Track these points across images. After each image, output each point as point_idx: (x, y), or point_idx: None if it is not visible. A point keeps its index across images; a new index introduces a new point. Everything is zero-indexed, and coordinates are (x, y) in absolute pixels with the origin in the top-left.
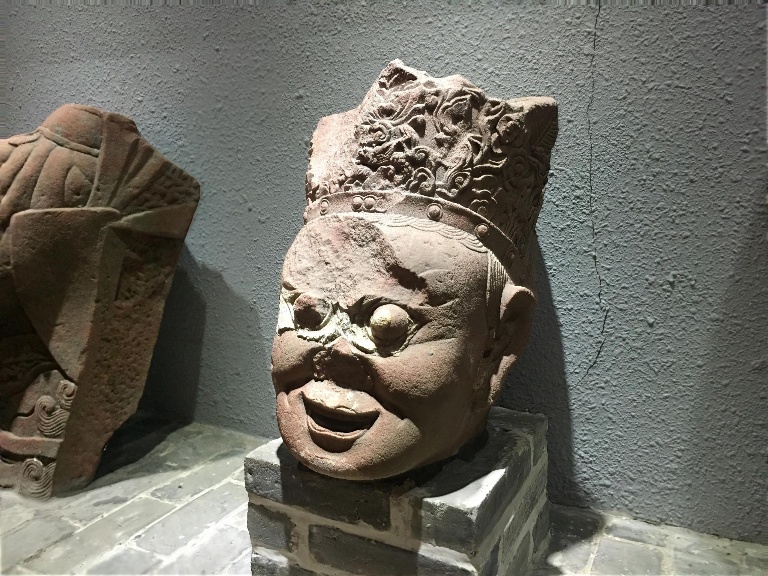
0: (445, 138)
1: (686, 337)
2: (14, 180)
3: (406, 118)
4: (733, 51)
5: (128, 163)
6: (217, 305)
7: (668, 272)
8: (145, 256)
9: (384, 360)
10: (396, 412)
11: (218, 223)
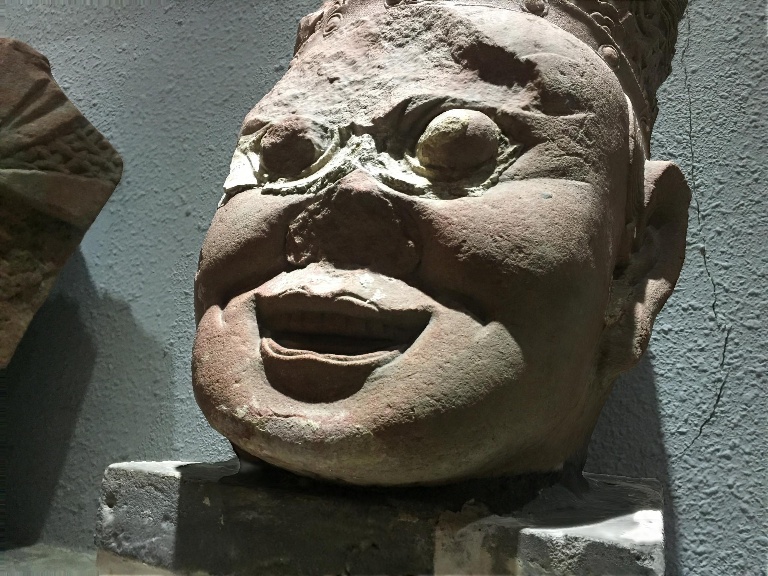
0: None
1: None
2: None
3: None
4: None
5: (25, 104)
6: (114, 351)
7: None
8: (18, 236)
9: (448, 202)
10: (470, 309)
11: (139, 234)
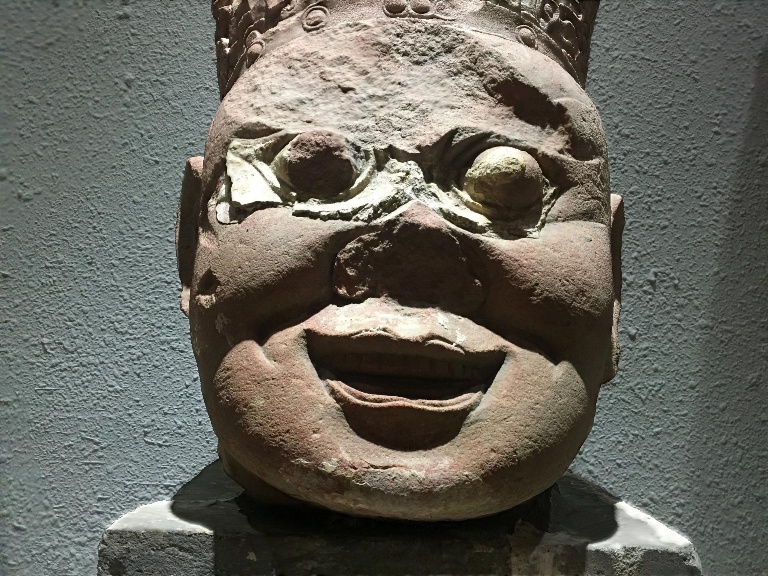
0: None
1: (674, 351)
2: None
3: None
4: (695, 29)
5: None
6: None
7: (648, 269)
8: None
9: (513, 243)
10: (542, 349)
11: None
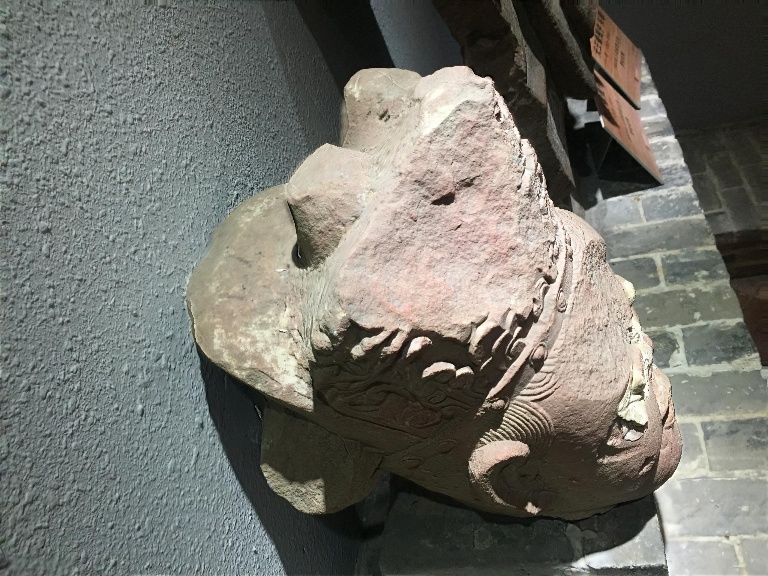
0: None
1: None
2: None
3: None
4: None
5: None
6: None
7: None
8: None
9: (635, 316)
10: None
11: None
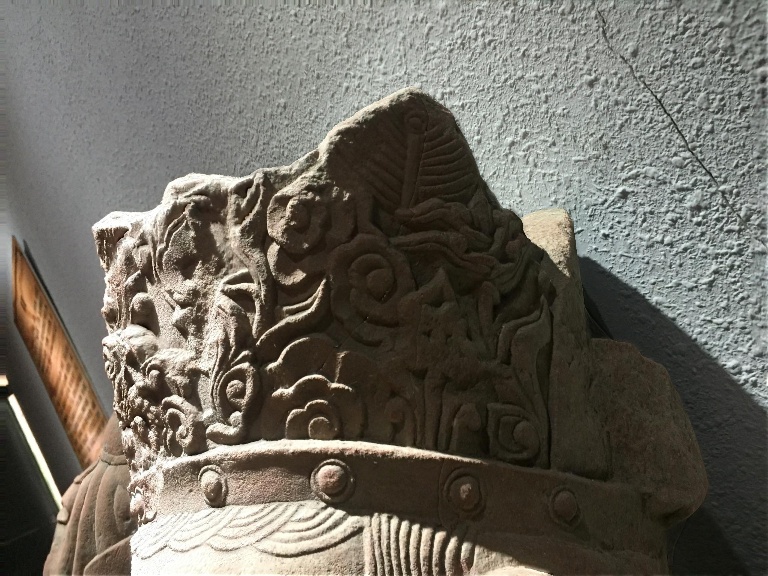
0: (183, 315)
1: None
2: (78, 527)
3: (126, 313)
4: None
5: None
6: None
7: None
8: None
9: None
10: None
11: None
